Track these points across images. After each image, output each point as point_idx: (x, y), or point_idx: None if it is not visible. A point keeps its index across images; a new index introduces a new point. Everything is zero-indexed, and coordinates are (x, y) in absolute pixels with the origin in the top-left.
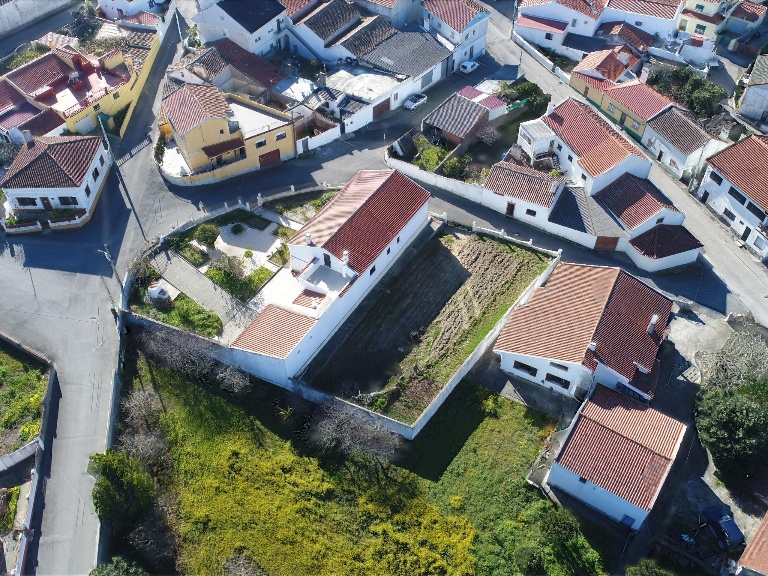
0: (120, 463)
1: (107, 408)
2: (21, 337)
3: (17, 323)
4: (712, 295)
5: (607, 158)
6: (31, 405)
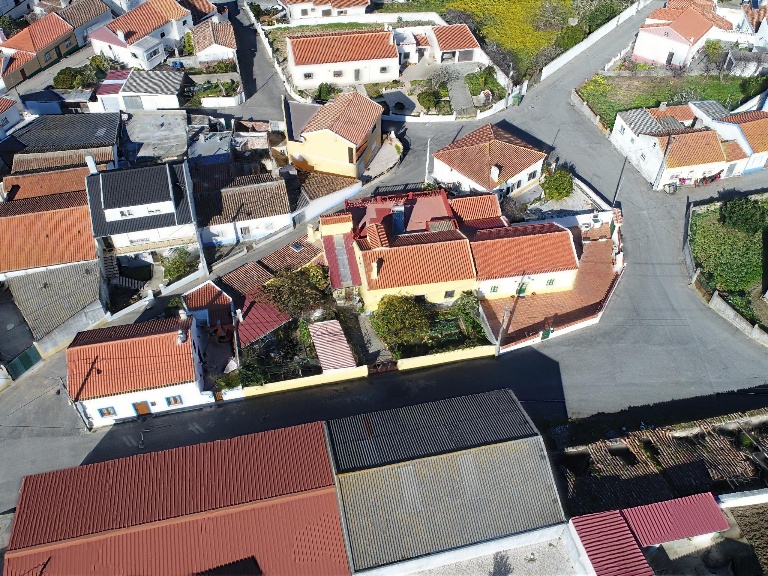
0: (570, 29)
1: (556, 77)
2: (581, 118)
3: (580, 124)
4: (226, 5)
5: (170, 6)
6: (594, 84)
